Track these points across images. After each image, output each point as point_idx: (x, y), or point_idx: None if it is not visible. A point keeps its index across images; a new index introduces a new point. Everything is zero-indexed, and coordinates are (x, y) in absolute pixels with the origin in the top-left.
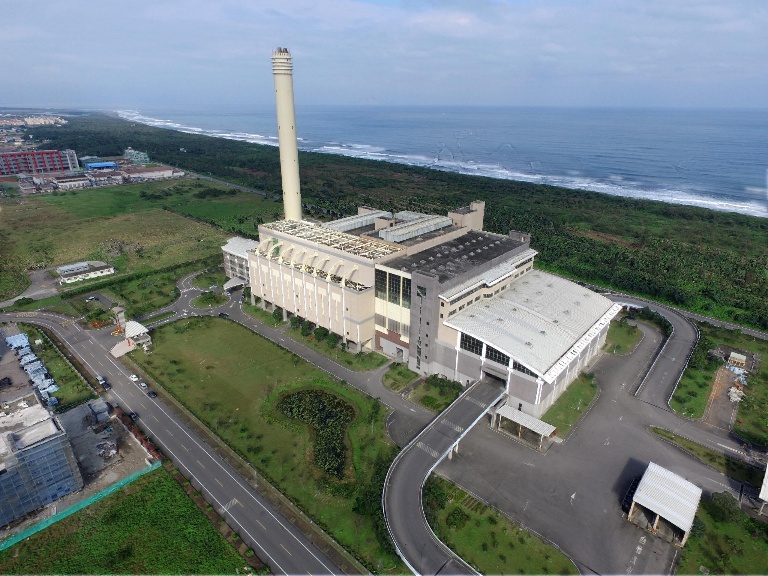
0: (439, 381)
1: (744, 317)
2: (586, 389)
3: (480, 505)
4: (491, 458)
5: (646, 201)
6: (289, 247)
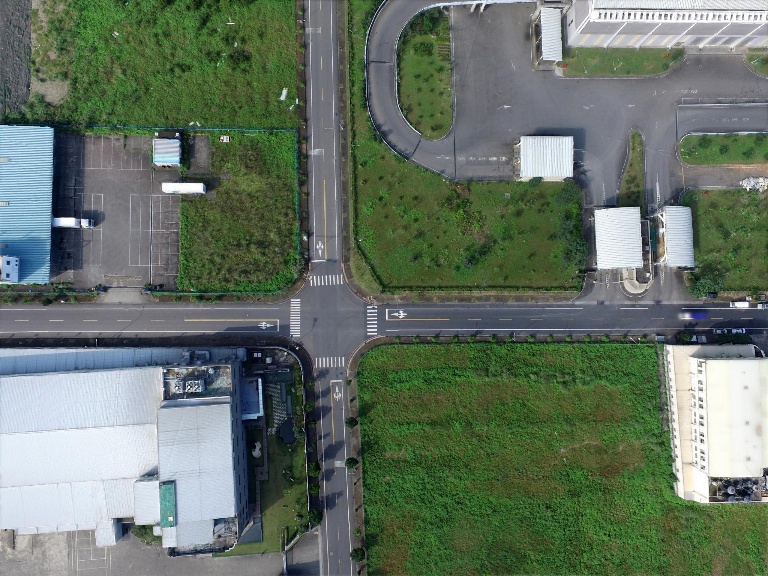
0: None
1: None
2: (654, 63)
3: (445, 55)
4: (497, 37)
5: None
6: None
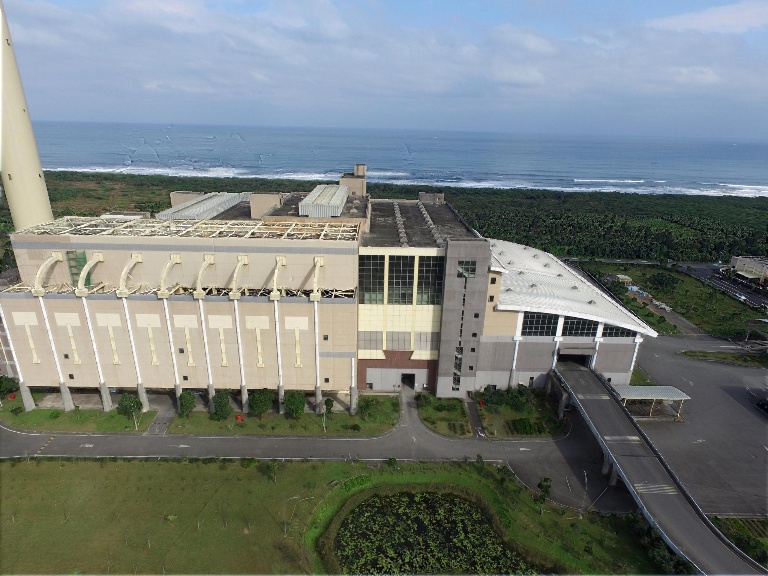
0: (506, 393)
1: (575, 250)
2: None
3: None
4: (672, 457)
5: (382, 184)
6: (132, 260)
